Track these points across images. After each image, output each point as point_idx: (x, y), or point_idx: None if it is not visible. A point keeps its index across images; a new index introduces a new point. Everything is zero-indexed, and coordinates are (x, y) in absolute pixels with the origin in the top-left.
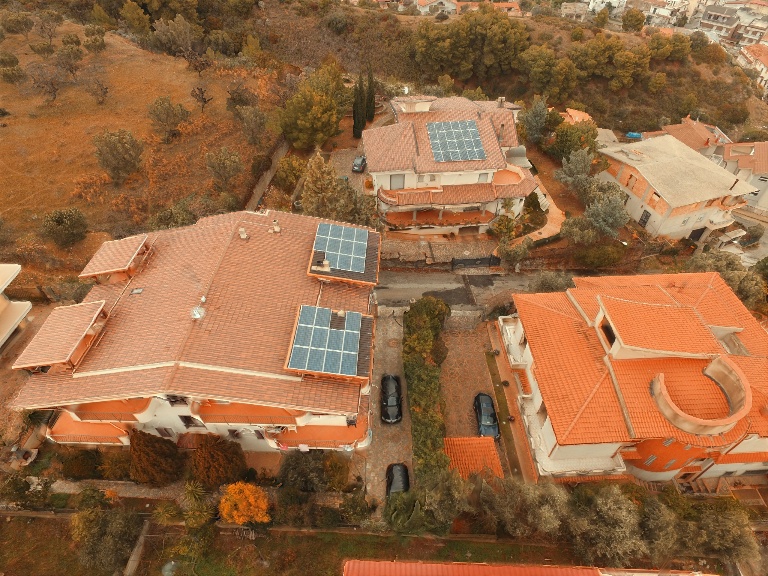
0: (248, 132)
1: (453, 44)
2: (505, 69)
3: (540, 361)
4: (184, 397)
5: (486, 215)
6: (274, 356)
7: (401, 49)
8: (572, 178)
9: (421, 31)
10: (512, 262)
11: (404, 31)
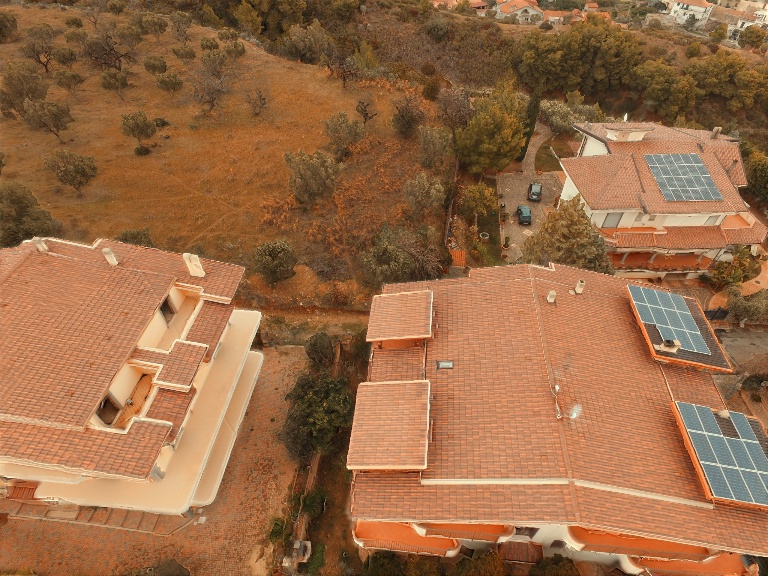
0: (429, 154)
1: (562, 56)
2: (614, 84)
3: None
4: (590, 529)
5: (702, 260)
6: (667, 471)
7: (503, 59)
8: None
9: (530, 41)
10: (739, 316)
11: (506, 40)
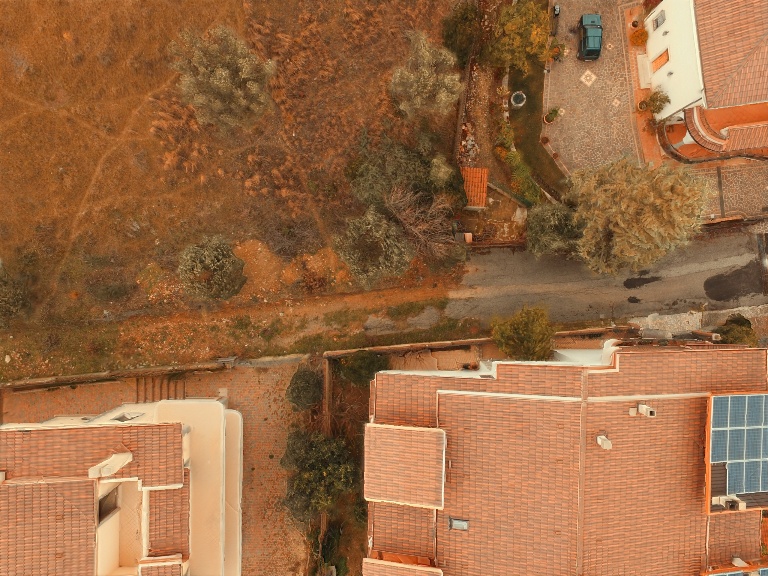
0: None
1: None
2: None
3: None
4: None
5: None
6: None
7: None
8: None
9: None
10: None
11: None
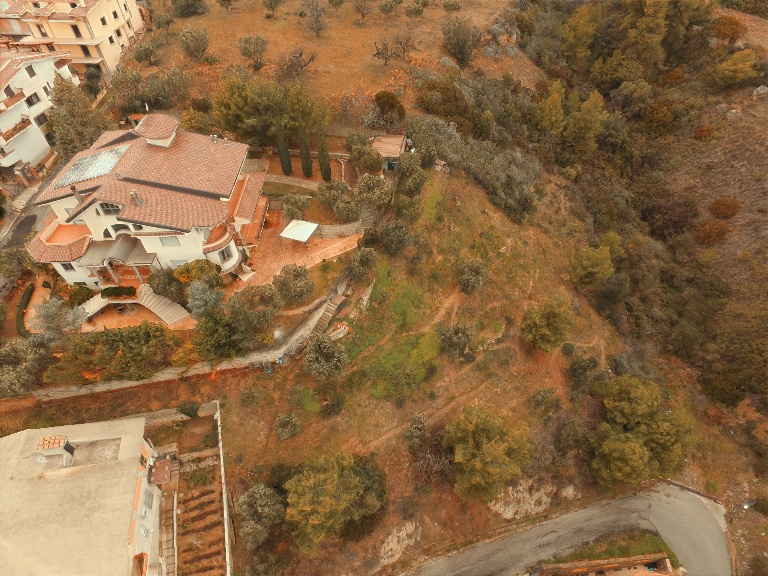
0: None
1: None
2: None
3: None
4: None
5: None
6: None
7: None
8: None
9: None
10: None
11: None
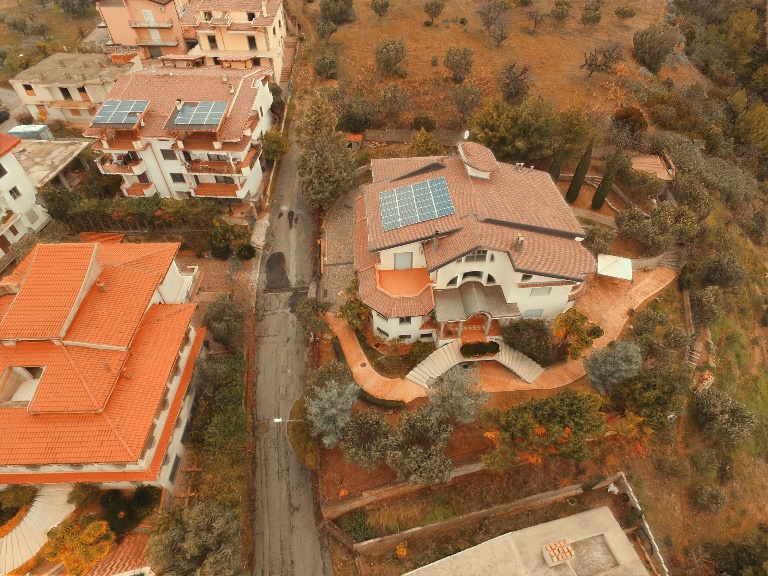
0: None
1: None
2: None
3: (103, 245)
4: None
5: None
6: None
7: None
8: (437, 387)
9: None
10: None
11: None
